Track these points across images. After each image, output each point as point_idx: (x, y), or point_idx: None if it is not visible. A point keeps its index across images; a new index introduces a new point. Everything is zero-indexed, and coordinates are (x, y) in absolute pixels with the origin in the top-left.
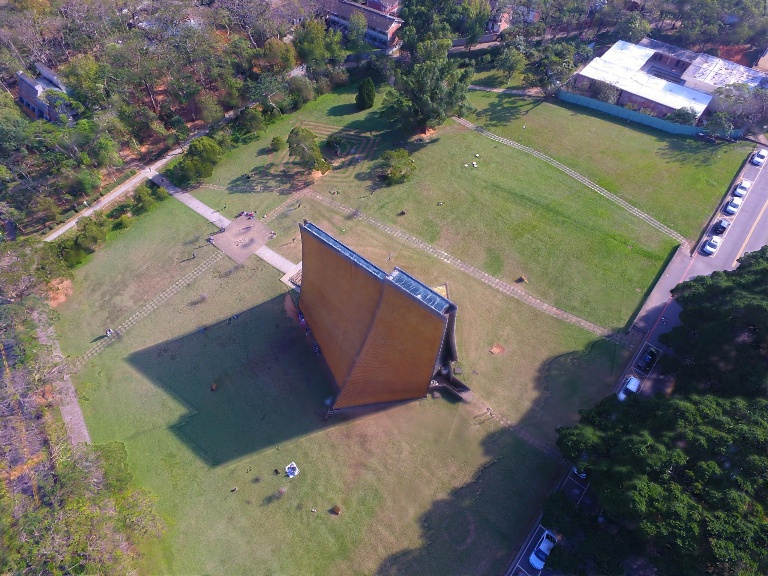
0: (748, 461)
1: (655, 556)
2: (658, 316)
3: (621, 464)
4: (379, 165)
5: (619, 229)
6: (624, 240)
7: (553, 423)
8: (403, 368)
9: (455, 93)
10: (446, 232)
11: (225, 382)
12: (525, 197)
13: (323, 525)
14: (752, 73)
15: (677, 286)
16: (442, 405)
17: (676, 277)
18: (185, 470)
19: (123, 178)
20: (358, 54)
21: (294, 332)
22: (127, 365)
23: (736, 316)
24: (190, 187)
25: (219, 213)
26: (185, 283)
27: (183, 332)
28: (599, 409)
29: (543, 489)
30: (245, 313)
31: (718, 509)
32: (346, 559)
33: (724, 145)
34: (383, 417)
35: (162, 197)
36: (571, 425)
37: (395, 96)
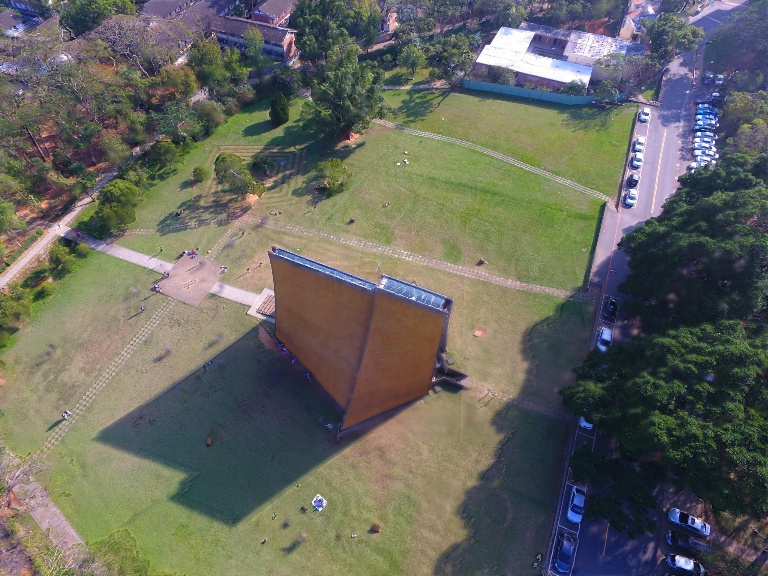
0: (732, 375)
1: (675, 479)
2: (607, 269)
3: (631, 407)
4: (313, 178)
5: (552, 198)
6: (559, 207)
7: (549, 387)
8: (405, 371)
9: (373, 96)
10: (399, 231)
11: (219, 433)
12: (462, 184)
13: (367, 547)
14: (618, 43)
15: (623, 239)
16: (446, 397)
17: (611, 232)
18: (204, 537)
19: (29, 241)
20: (259, 70)
21: (278, 363)
22: (100, 445)
23: (681, 255)
24: (113, 237)
25: (157, 258)
26: (141, 340)
27: (155, 393)
28: (590, 363)
29: (559, 449)
30: (219, 356)
31: (723, 422)
32: (400, 573)
33: (614, 109)
34: (394, 424)
35: (84, 253)
36: (565, 384)
37: (311, 107)
